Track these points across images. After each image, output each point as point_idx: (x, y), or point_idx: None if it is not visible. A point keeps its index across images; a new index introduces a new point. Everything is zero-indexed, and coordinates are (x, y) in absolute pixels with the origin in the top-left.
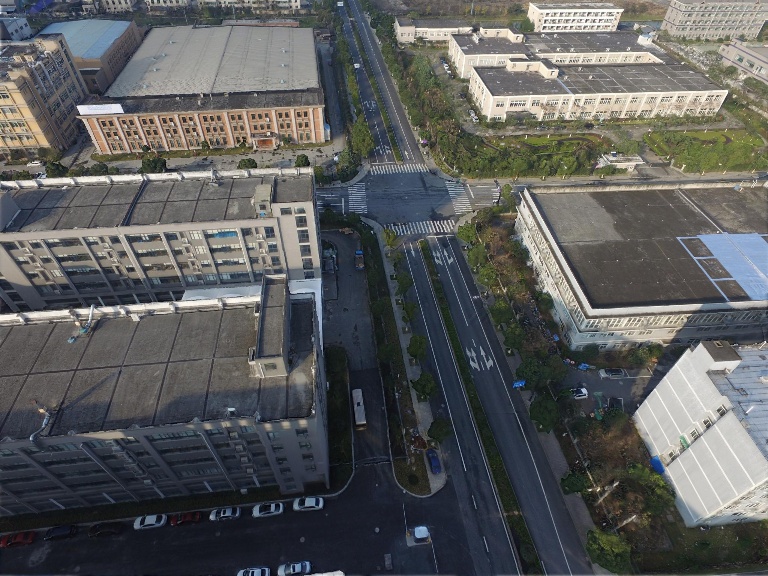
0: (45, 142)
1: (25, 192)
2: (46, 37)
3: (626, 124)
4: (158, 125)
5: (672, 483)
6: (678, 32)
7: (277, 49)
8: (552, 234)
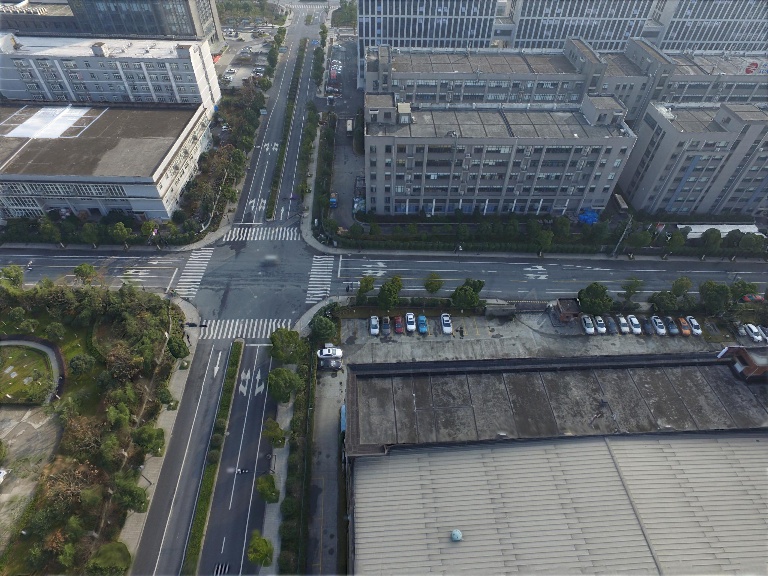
0: None
1: None
2: None
3: None
4: None
5: None
6: None
7: None
8: None
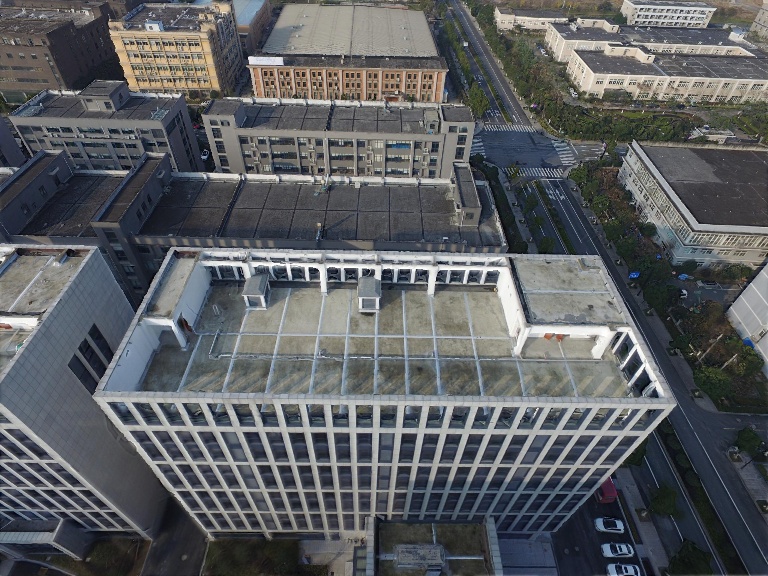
0: (217, 86)
1: (245, 106)
2: (221, 1)
3: (716, 107)
4: (308, 78)
5: (761, 354)
6: (767, 34)
7: (397, 26)
8: (660, 173)
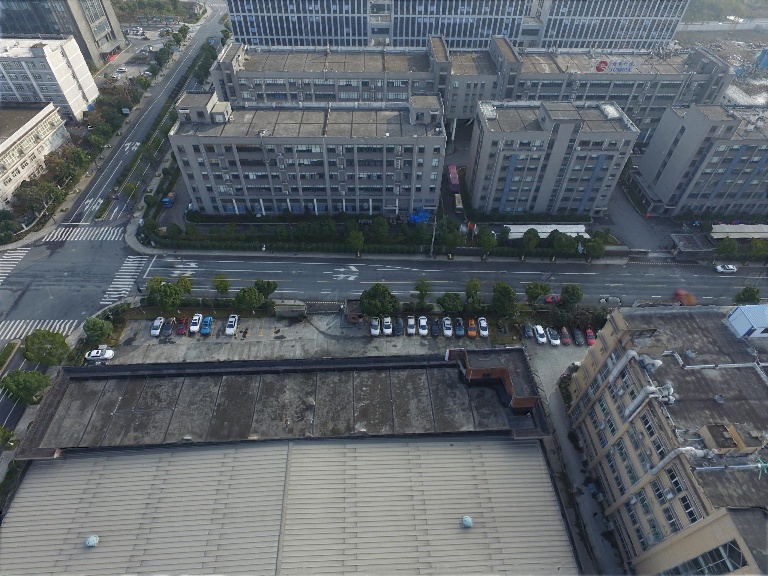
0: None
1: None
2: None
3: None
4: None
5: None
6: None
7: None
8: None
